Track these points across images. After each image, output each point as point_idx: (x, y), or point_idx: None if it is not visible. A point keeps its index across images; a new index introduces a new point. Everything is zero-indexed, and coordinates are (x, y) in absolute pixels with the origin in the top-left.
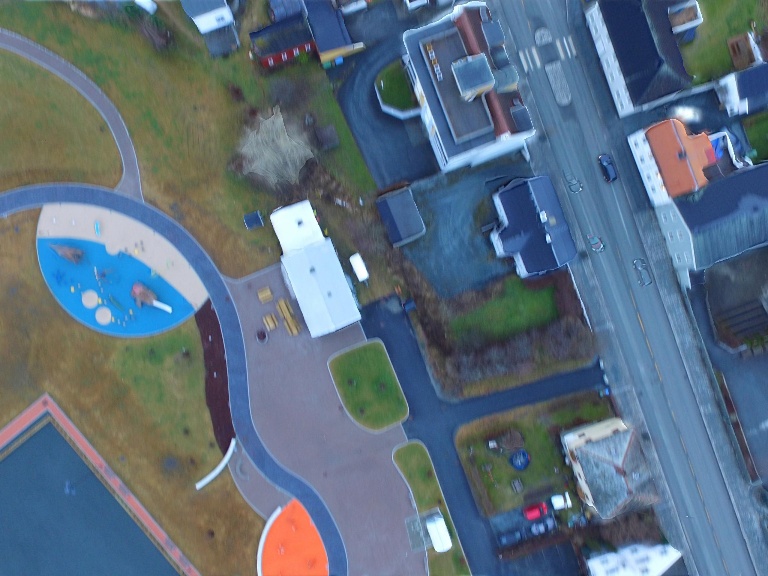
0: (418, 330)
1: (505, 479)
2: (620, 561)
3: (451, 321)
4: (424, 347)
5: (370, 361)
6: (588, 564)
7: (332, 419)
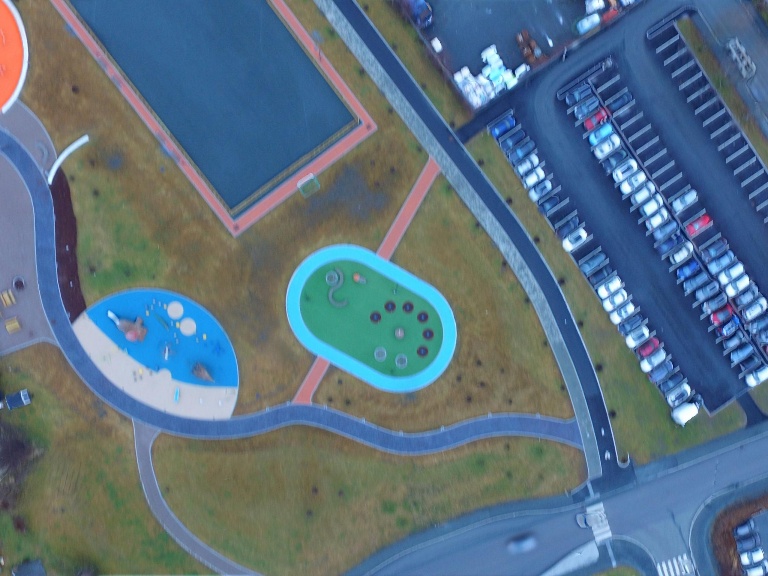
0: None
1: None
2: None
3: None
4: None
5: None
6: None
7: None
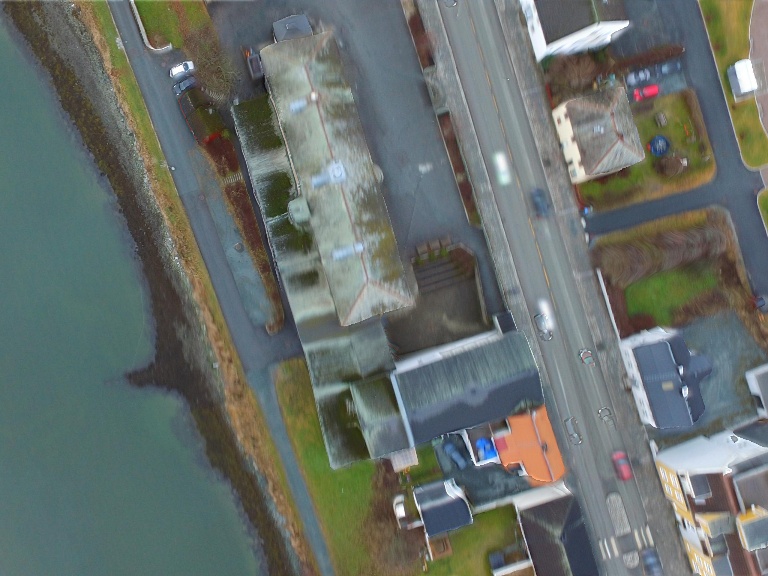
0: (744, 278)
1: (672, 127)
2: None
3: (717, 286)
4: (740, 261)
5: None
6: None
7: None
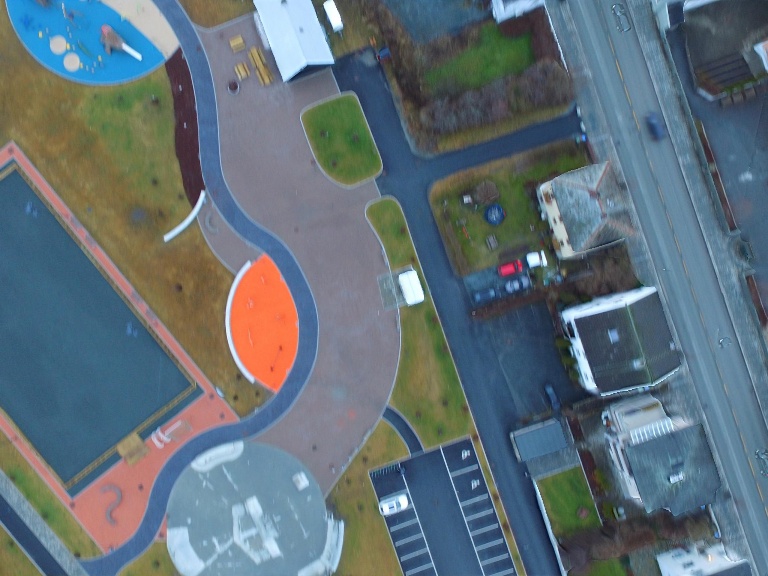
0: (393, 84)
1: (480, 236)
2: (594, 304)
3: (426, 73)
4: (399, 101)
5: (343, 113)
6: (562, 315)
7: (304, 173)
